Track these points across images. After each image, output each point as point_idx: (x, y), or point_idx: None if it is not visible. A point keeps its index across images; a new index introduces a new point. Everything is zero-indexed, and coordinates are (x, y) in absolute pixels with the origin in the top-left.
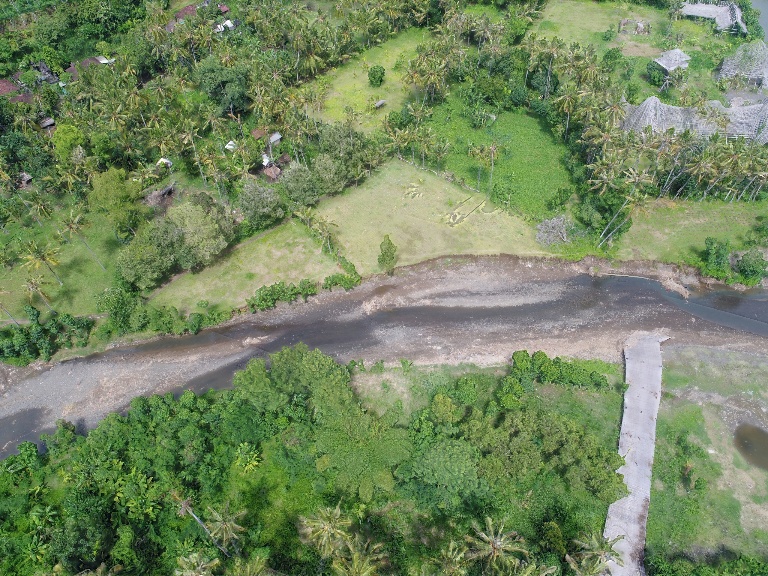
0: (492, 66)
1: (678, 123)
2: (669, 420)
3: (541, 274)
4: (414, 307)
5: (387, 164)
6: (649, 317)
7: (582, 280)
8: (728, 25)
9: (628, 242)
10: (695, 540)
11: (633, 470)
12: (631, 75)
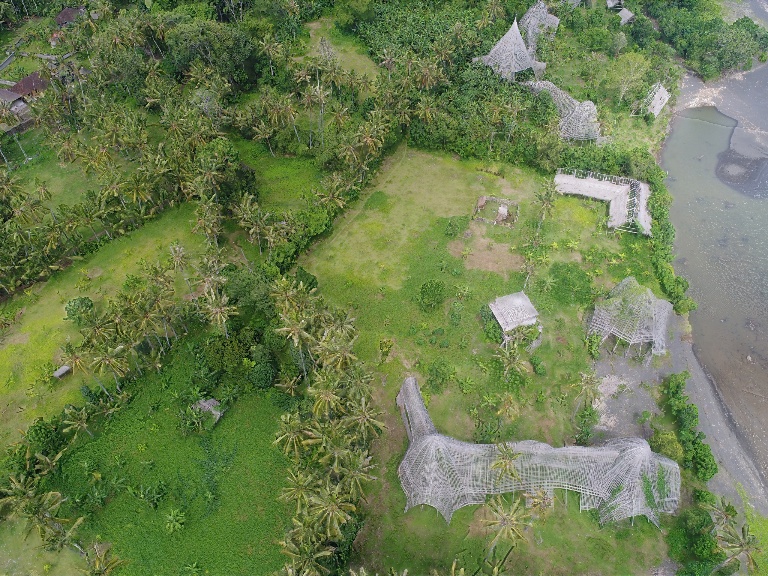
0: (249, 304)
1: (481, 474)
2: None
3: None
4: None
5: (15, 516)
6: None
7: None
8: (622, 223)
9: None
10: None
11: None
12: (457, 322)
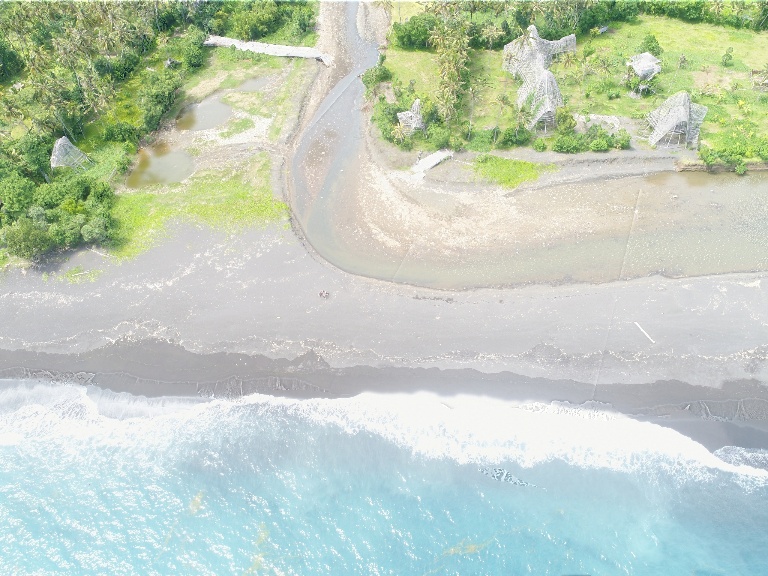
0: None
1: None
2: (275, 59)
3: (381, 33)
4: (358, 2)
5: None
6: (344, 63)
7: (376, 45)
8: None
9: (403, 54)
10: (217, 58)
11: (251, 45)
12: None
